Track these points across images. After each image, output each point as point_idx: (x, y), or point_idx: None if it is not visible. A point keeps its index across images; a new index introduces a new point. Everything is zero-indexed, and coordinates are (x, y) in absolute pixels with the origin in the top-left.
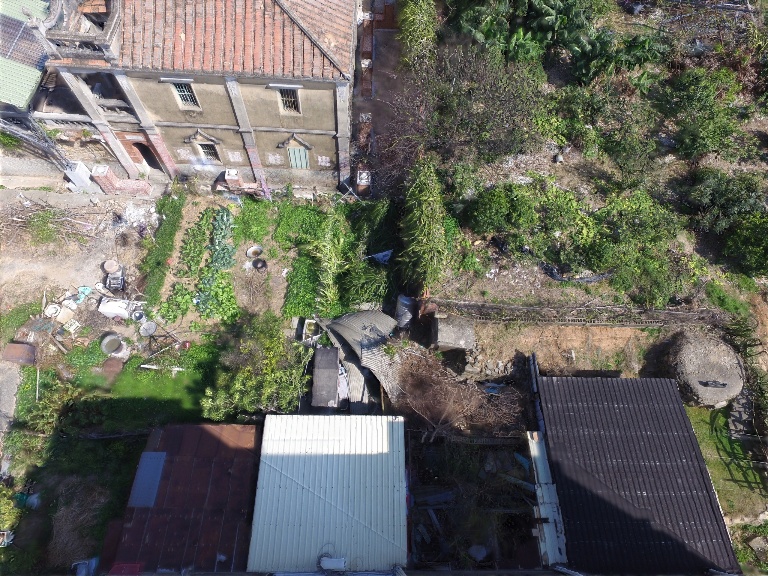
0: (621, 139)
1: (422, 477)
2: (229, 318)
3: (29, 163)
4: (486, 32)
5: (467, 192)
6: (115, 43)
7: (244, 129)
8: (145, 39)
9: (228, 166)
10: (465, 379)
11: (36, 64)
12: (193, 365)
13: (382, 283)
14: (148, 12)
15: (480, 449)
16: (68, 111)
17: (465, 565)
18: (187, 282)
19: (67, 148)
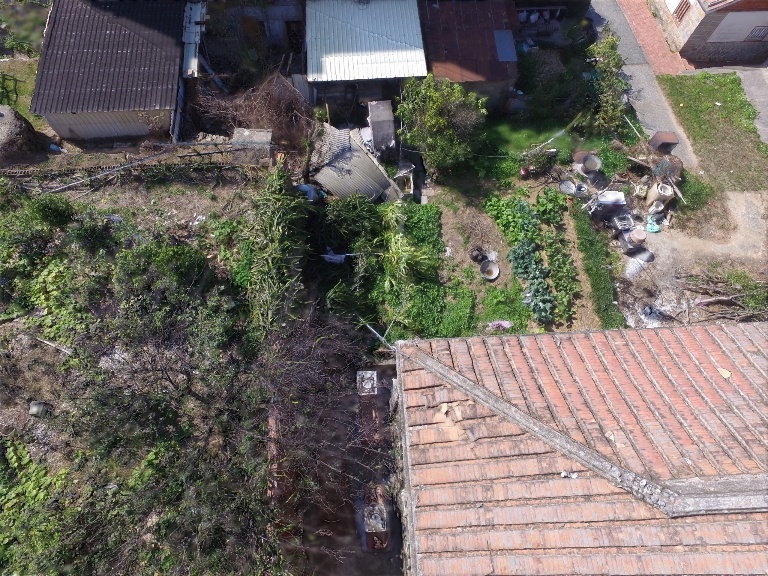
0: None
1: None
2: None
3: None
4: None
5: (212, 300)
6: None
7: None
8: None
9: None
10: None
11: None
12: None
13: None
14: None
15: None
16: None
17: (264, 1)
18: None
19: None
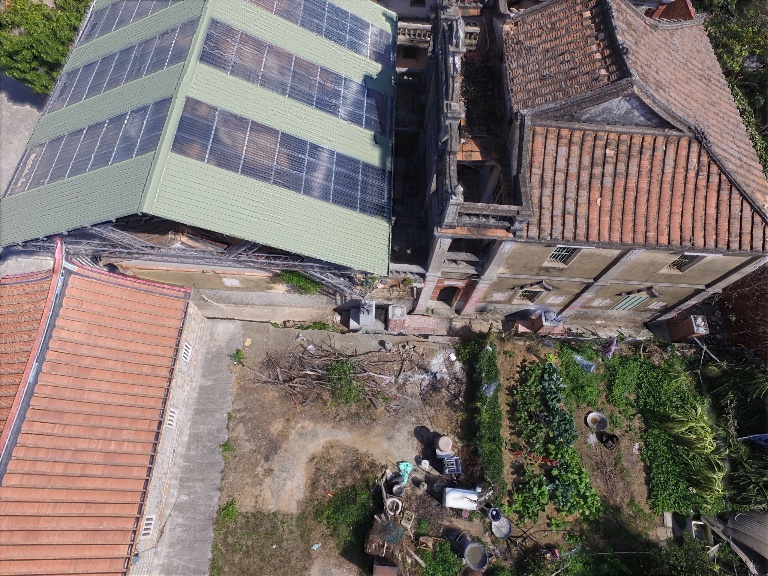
0: None
1: None
2: (596, 515)
3: (307, 298)
4: None
5: None
6: None
7: (600, 283)
8: (555, 205)
9: (537, 306)
10: None
11: (383, 215)
12: None
13: None
14: (559, 172)
15: None
16: None
17: None
18: (529, 462)
19: None
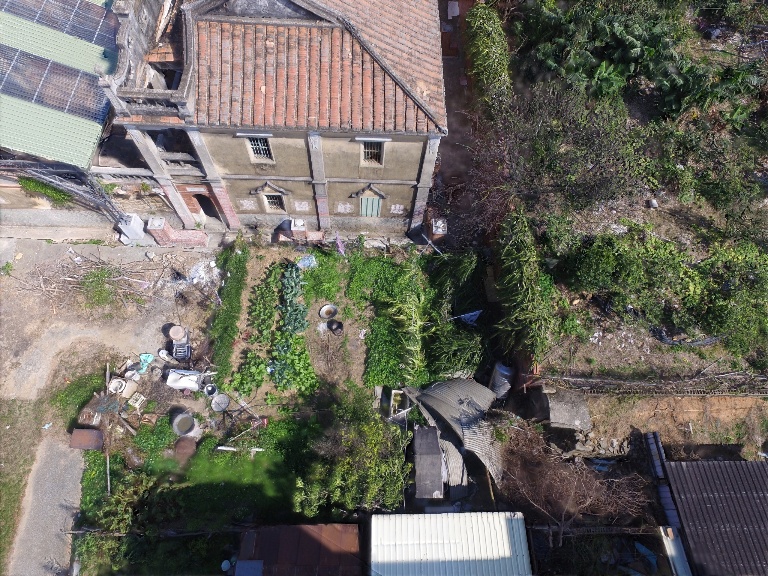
0: (719, 182)
1: (540, 575)
2: (308, 389)
3: (78, 215)
4: (567, 66)
5: (564, 247)
6: (190, 98)
7: (318, 181)
8: (222, 93)
9: (292, 215)
10: (572, 456)
11: (96, 117)
12: (274, 445)
13: (477, 350)
14: (225, 63)
15: (596, 537)
16: (124, 162)
17: None
18: (258, 348)
19: (121, 200)
